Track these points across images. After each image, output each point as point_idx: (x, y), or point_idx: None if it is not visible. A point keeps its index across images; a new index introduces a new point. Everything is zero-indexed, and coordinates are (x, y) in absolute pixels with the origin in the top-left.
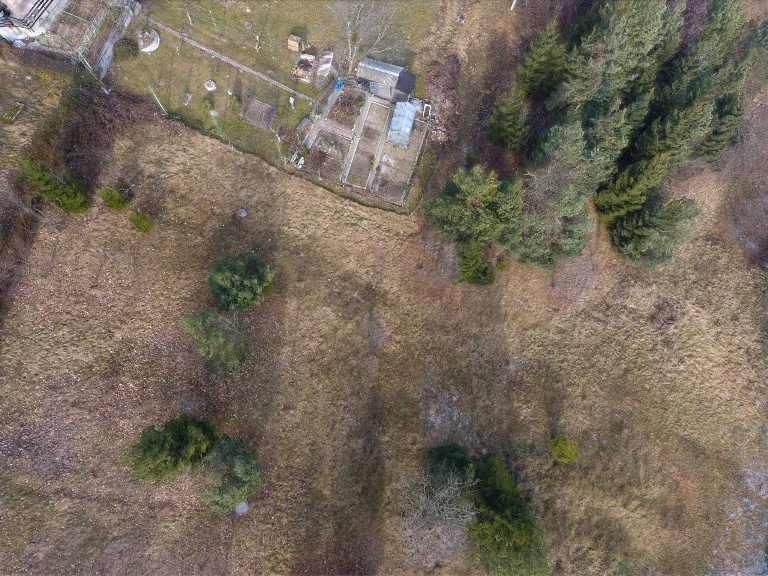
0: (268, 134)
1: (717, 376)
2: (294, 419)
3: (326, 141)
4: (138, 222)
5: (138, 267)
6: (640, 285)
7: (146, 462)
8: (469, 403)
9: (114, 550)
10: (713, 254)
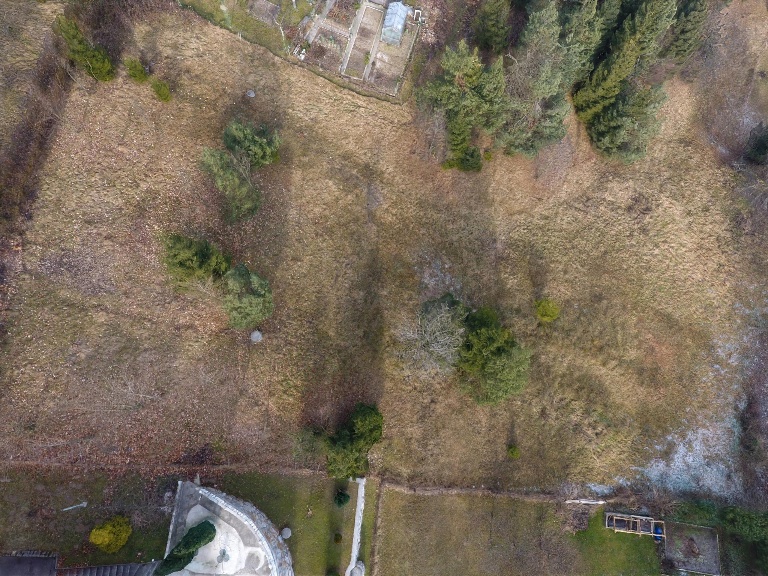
0: (273, 29)
1: (690, 260)
2: (301, 270)
3: (325, 38)
4: (159, 88)
5: (159, 131)
6: (618, 181)
7: (177, 249)
8: (460, 271)
9: (145, 359)
10: (686, 154)
